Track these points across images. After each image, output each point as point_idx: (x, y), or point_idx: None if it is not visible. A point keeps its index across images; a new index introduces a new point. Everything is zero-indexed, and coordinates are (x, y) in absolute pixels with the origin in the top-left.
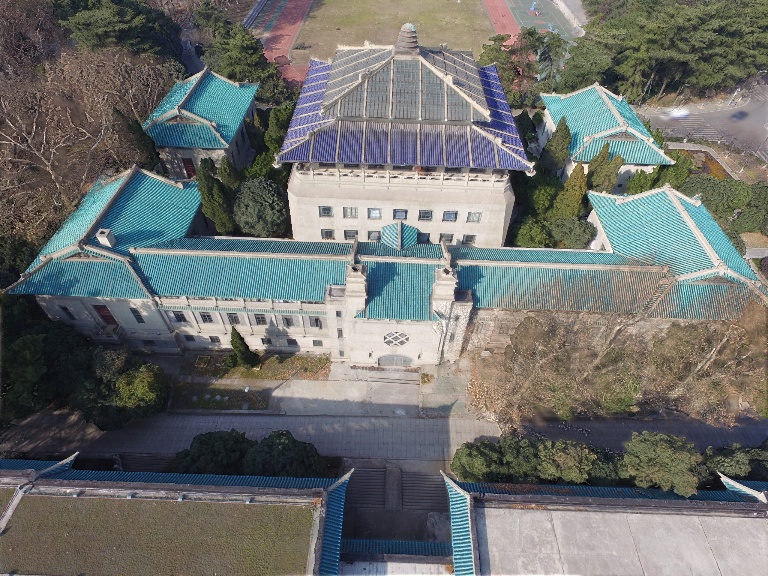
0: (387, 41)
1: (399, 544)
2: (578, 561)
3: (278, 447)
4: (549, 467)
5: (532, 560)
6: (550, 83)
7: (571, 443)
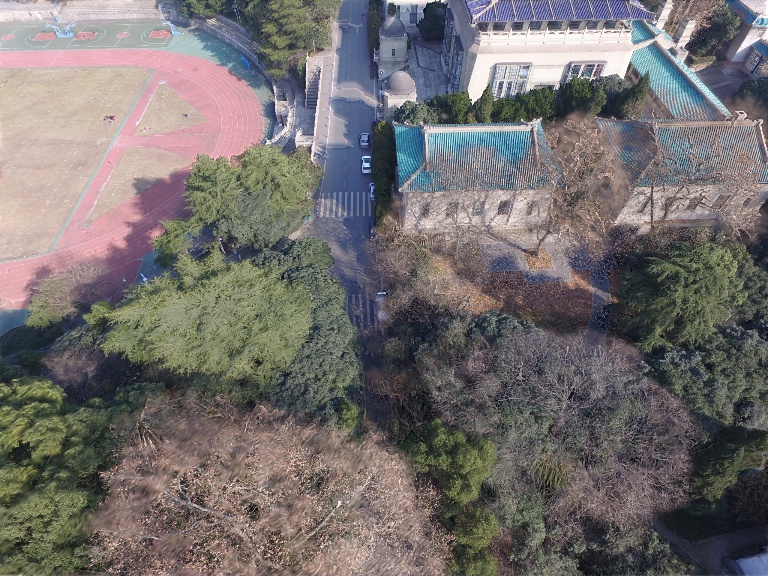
0: (2, 155)
1: (767, 54)
2: (755, 5)
3: (764, 80)
4: (726, 6)
5: (764, 11)
6: (319, 1)
7: (714, 0)
